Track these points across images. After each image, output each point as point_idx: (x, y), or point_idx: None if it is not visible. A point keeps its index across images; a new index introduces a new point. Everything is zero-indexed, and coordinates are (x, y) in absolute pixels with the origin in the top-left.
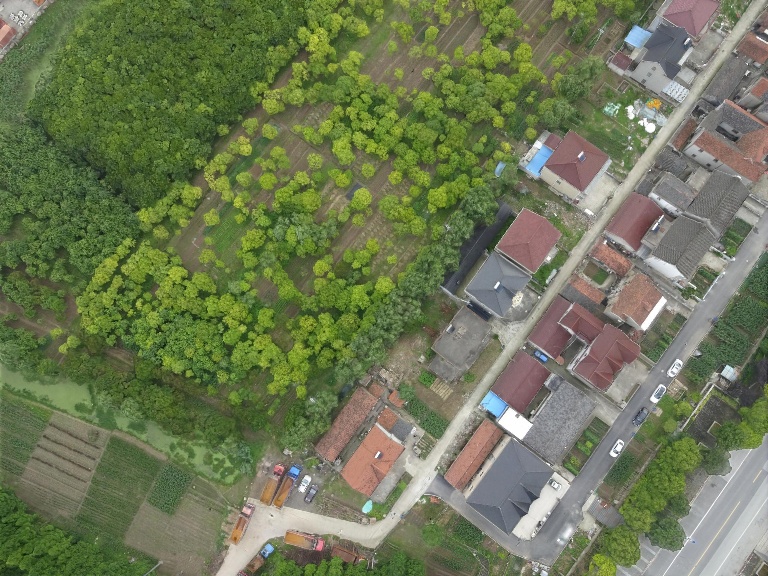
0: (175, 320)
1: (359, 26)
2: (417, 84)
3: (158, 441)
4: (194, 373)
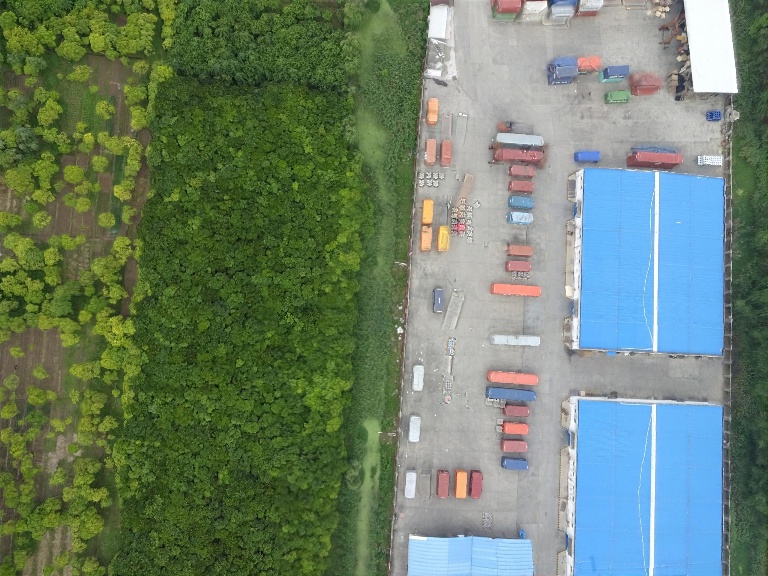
0: (65, 0)
1: (80, 370)
2: (5, 359)
3: None
4: None
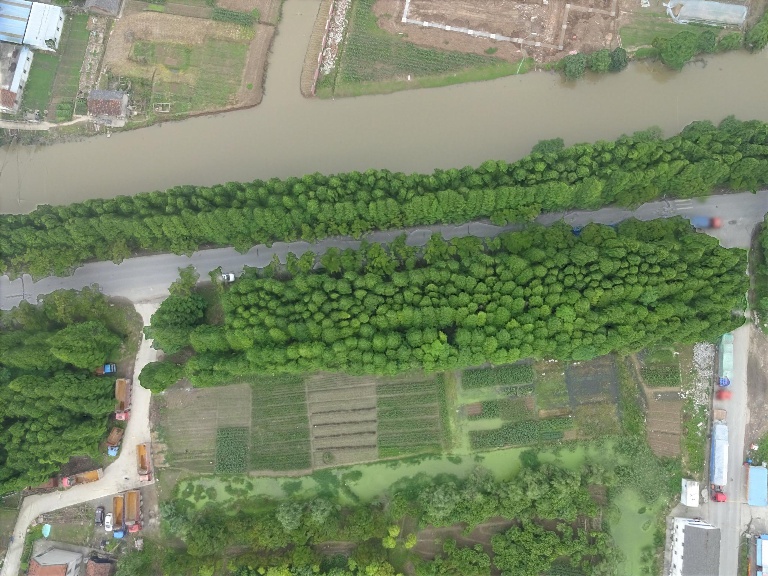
0: None
1: None
2: None
3: (266, 485)
4: (258, 573)
